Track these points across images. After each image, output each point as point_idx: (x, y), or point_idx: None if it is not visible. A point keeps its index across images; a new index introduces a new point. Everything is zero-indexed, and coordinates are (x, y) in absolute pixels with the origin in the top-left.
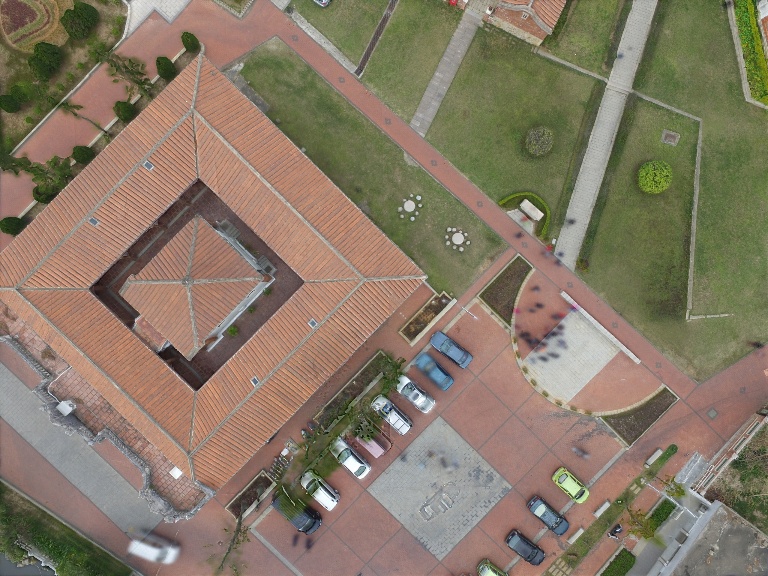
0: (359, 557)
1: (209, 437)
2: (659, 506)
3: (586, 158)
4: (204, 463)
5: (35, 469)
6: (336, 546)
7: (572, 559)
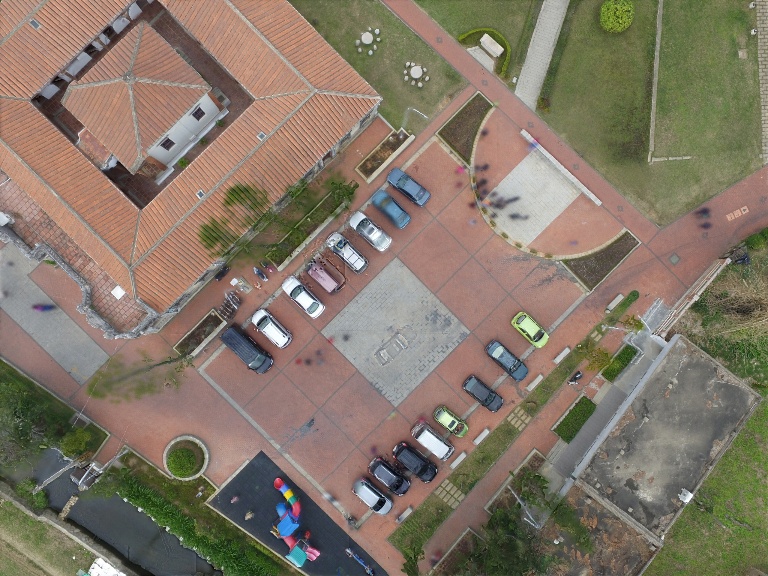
0: (312, 402)
1: (151, 249)
2: (620, 352)
3: None
4: (147, 280)
5: None
6: (288, 390)
7: (531, 407)
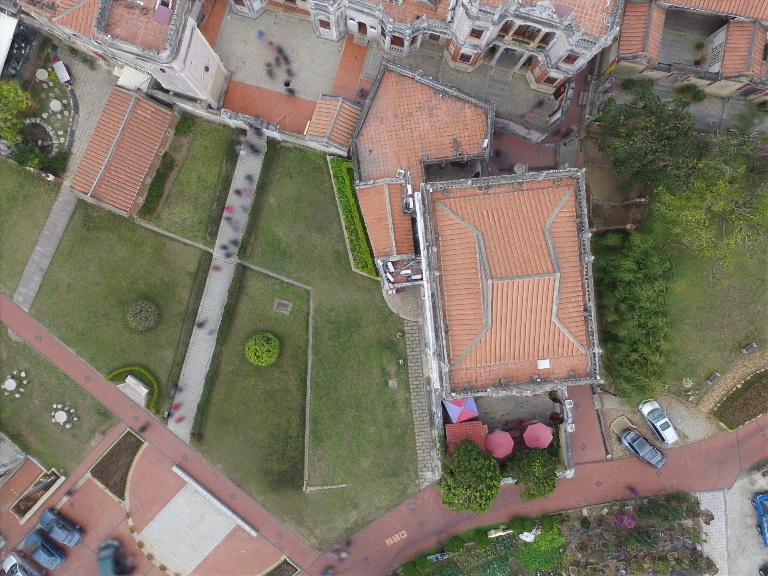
0: None
1: None
2: None
3: (196, 329)
4: None
5: None
6: None
7: None
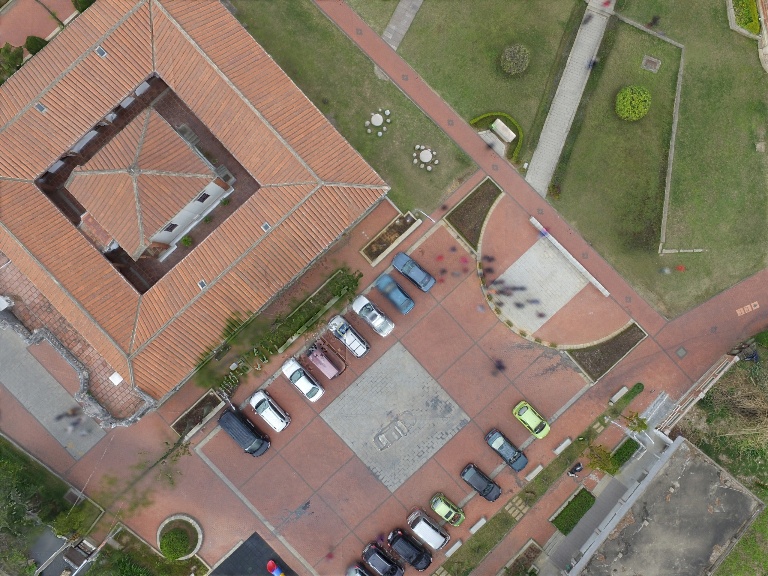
0: (308, 484)
1: (151, 340)
2: (622, 446)
3: (563, 81)
4: (145, 368)
5: None
6: (285, 472)
7: (529, 497)
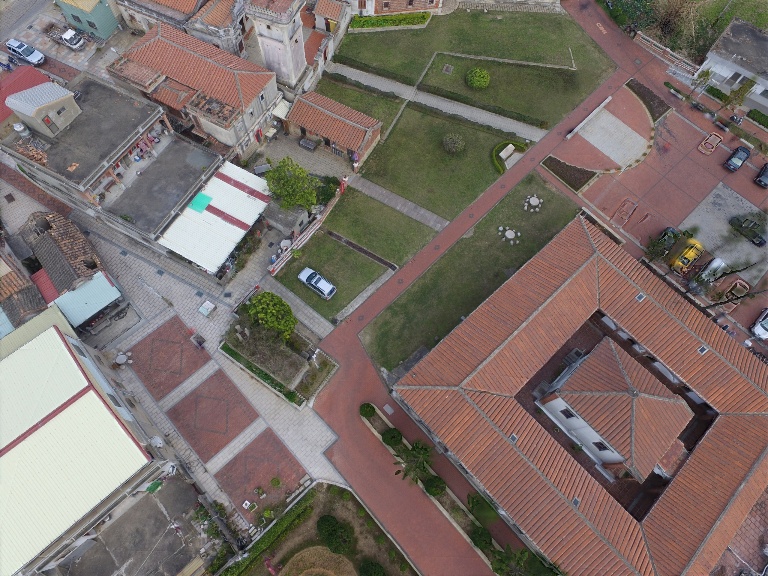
0: None
1: (767, 394)
2: (710, 94)
3: None
4: None
5: None
6: None
7: (764, 147)
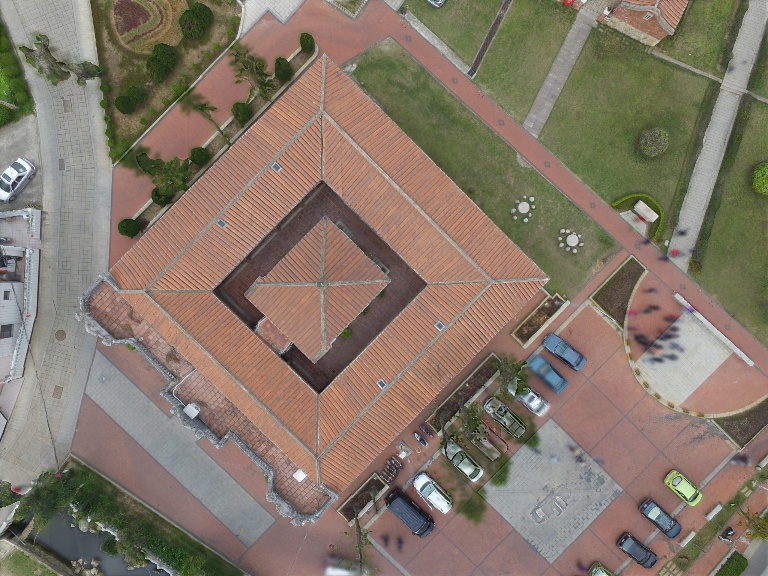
0: (470, 560)
1: (337, 440)
2: None
3: (699, 159)
4: (330, 466)
5: (147, 472)
6: (447, 549)
7: (683, 562)
